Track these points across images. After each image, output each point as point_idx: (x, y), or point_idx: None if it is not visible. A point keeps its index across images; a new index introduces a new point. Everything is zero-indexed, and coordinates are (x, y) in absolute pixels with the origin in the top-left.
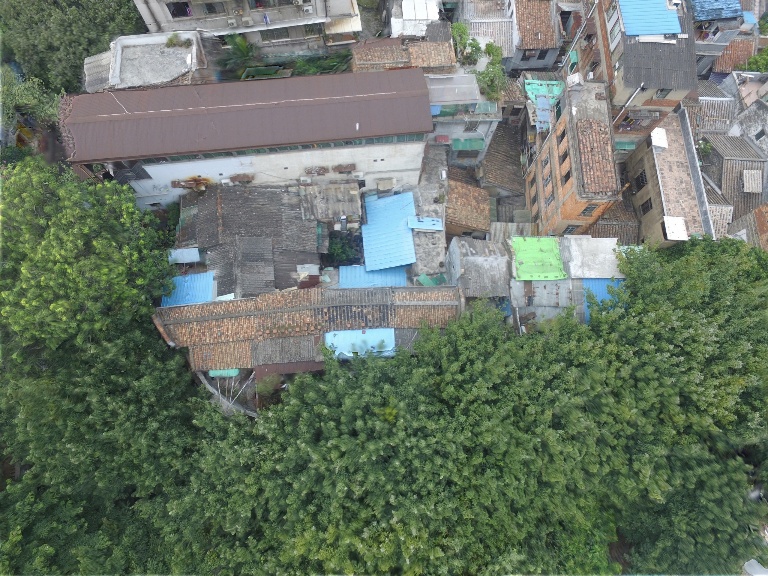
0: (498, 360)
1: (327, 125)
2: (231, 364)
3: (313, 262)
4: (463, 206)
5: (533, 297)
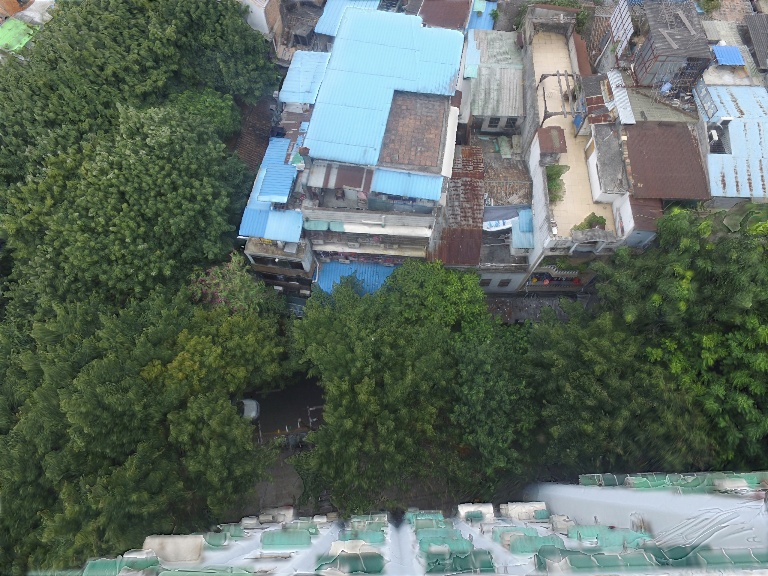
0: (7, 57)
1: None
2: None
3: None
4: None
5: None
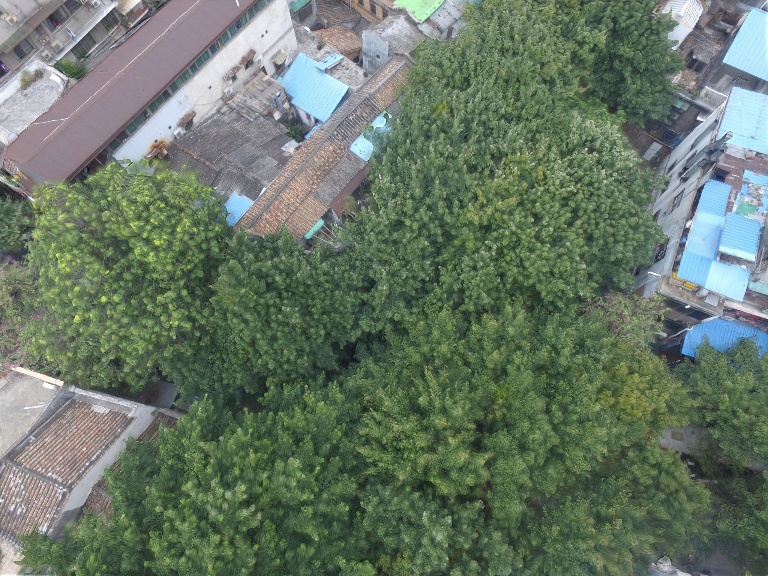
0: None
1: (216, 18)
2: (313, 219)
3: (288, 141)
4: (338, 41)
5: (439, 26)
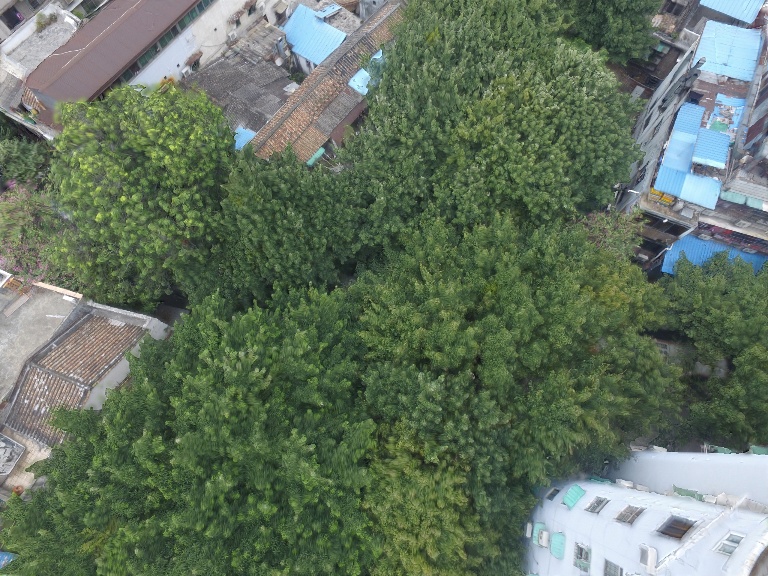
0: None
1: None
2: (315, 147)
3: (289, 83)
4: None
5: None
